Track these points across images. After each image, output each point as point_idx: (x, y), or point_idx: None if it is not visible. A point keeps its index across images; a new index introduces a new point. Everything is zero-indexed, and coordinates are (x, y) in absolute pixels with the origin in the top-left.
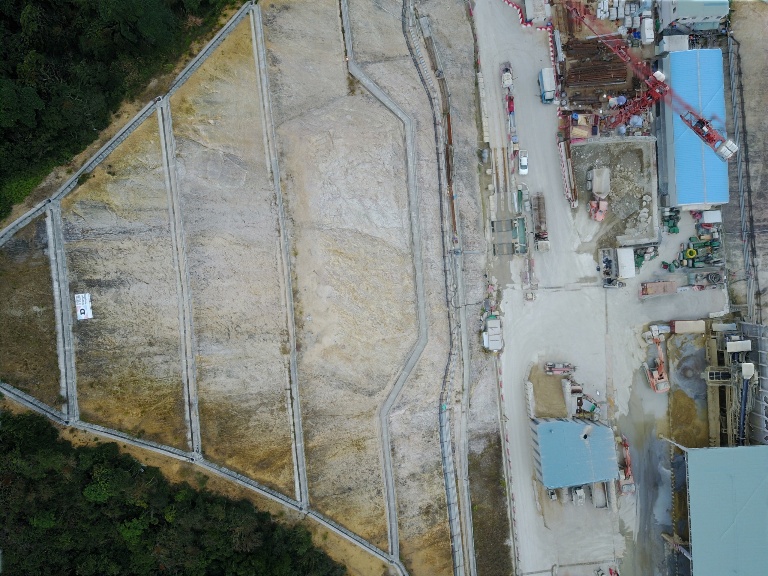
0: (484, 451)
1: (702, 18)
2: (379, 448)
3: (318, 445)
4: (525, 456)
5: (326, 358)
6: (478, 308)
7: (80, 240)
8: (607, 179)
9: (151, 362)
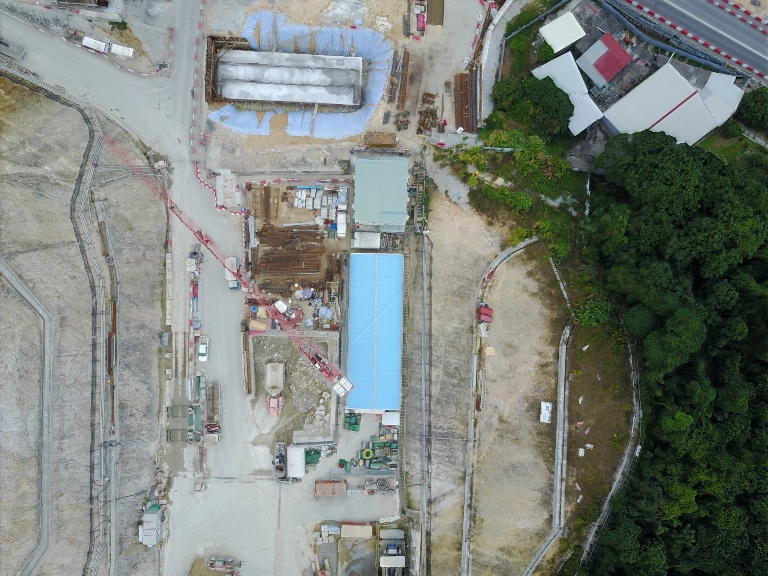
0: None
1: (383, 223)
2: None
3: None
4: None
5: None
6: (140, 498)
7: None
8: (281, 375)
9: None
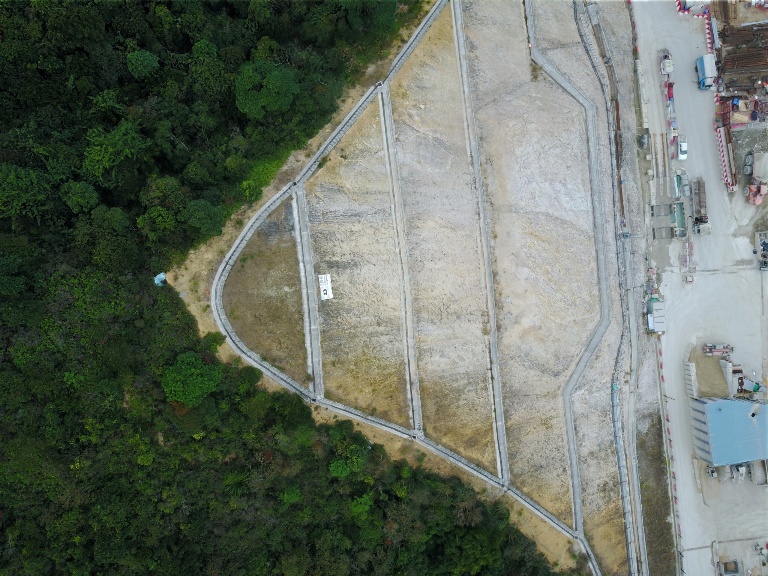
0: (648, 431)
1: None
2: (563, 427)
3: (515, 424)
4: (684, 435)
5: (523, 339)
6: (641, 291)
7: (321, 222)
8: (767, 163)
9: (379, 342)
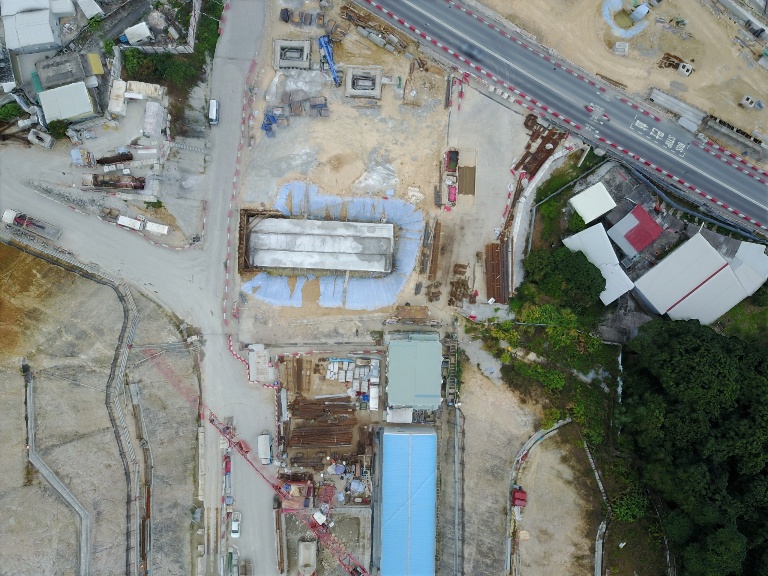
0: None
1: None
2: None
3: None
4: None
5: None
6: None
7: None
8: (314, 555)
9: None
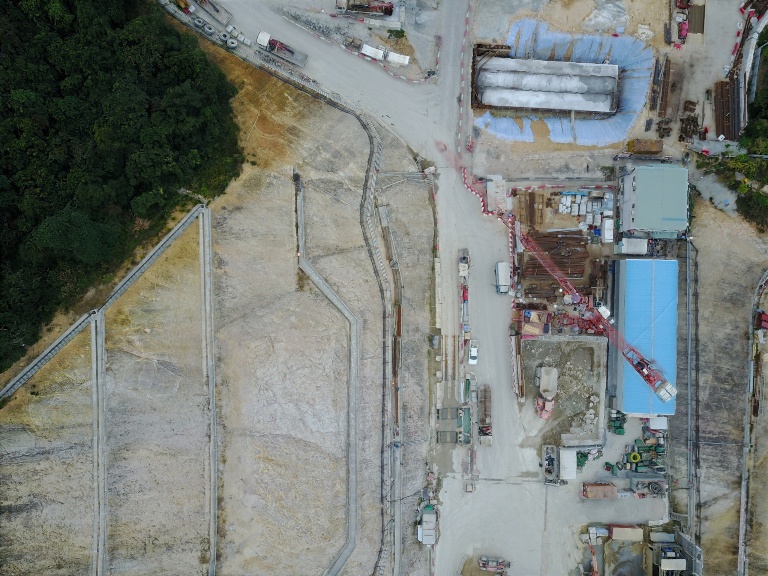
0: None
1: (660, 230)
2: None
3: None
4: None
5: (246, 568)
6: (415, 498)
7: None
8: (555, 379)
9: None
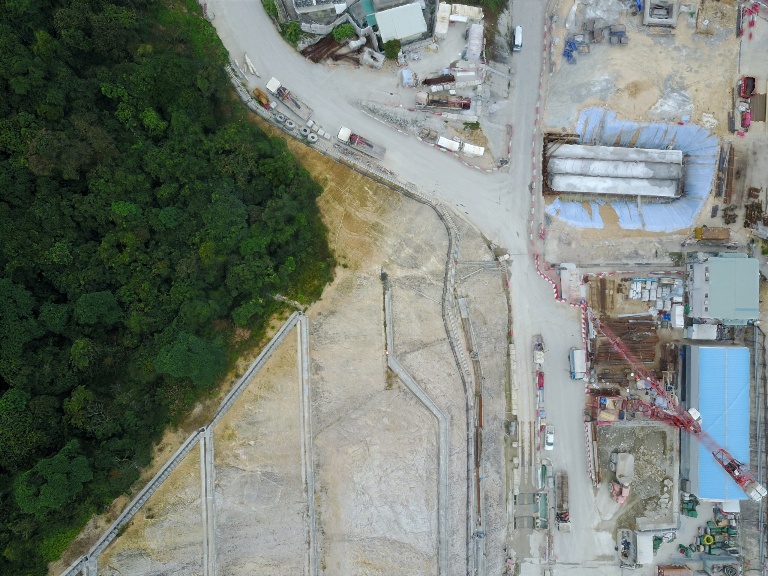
0: None
1: (732, 319)
2: None
3: None
4: None
5: None
6: None
7: None
8: (631, 465)
9: None
